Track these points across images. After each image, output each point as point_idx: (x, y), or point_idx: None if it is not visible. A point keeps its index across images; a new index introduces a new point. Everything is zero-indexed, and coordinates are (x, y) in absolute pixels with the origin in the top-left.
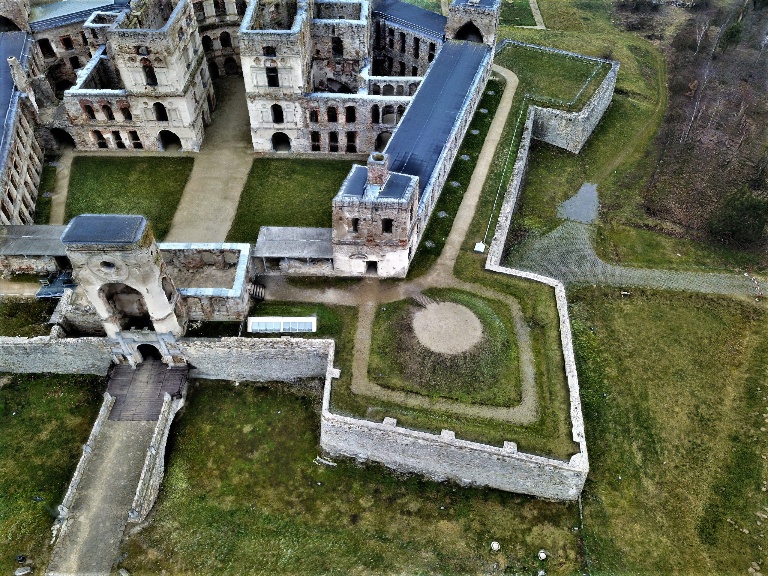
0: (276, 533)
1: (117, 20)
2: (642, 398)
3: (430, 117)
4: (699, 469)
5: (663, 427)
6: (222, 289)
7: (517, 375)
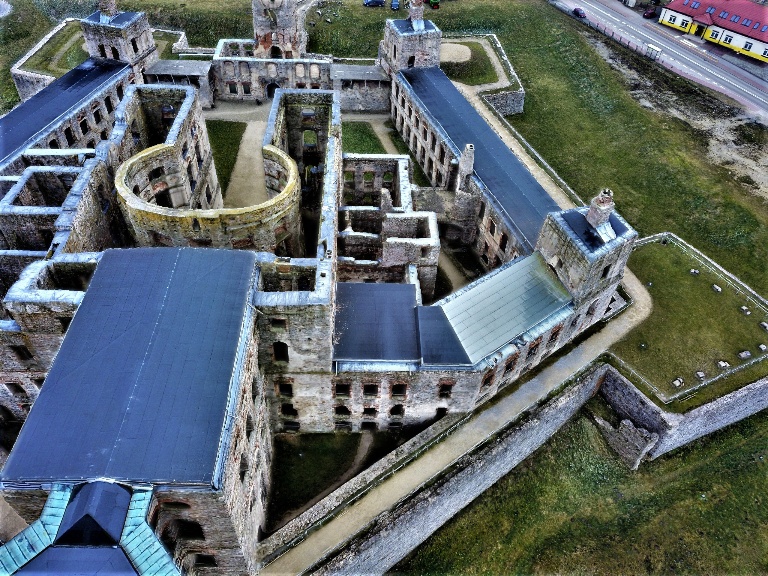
0: (217, 42)
1: (337, 104)
2: (5, 70)
3: (24, 120)
4: (6, 50)
5: (7, 61)
6: (230, 40)
7: (76, 43)
